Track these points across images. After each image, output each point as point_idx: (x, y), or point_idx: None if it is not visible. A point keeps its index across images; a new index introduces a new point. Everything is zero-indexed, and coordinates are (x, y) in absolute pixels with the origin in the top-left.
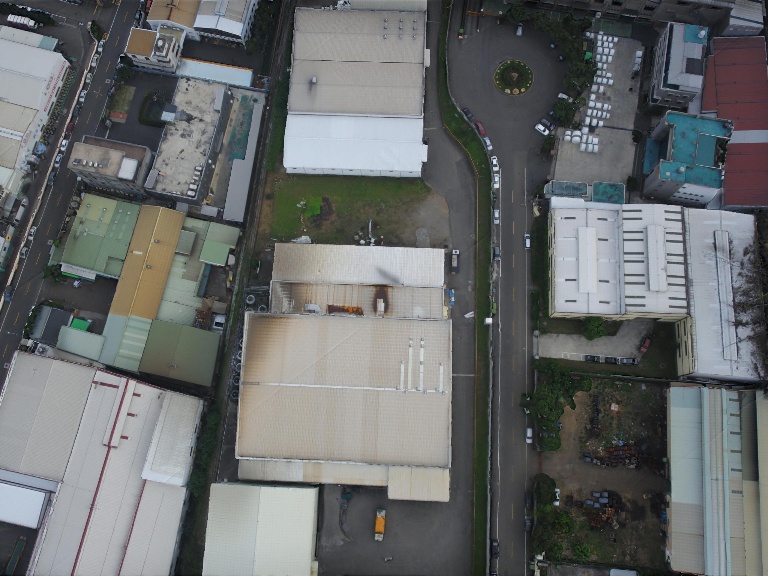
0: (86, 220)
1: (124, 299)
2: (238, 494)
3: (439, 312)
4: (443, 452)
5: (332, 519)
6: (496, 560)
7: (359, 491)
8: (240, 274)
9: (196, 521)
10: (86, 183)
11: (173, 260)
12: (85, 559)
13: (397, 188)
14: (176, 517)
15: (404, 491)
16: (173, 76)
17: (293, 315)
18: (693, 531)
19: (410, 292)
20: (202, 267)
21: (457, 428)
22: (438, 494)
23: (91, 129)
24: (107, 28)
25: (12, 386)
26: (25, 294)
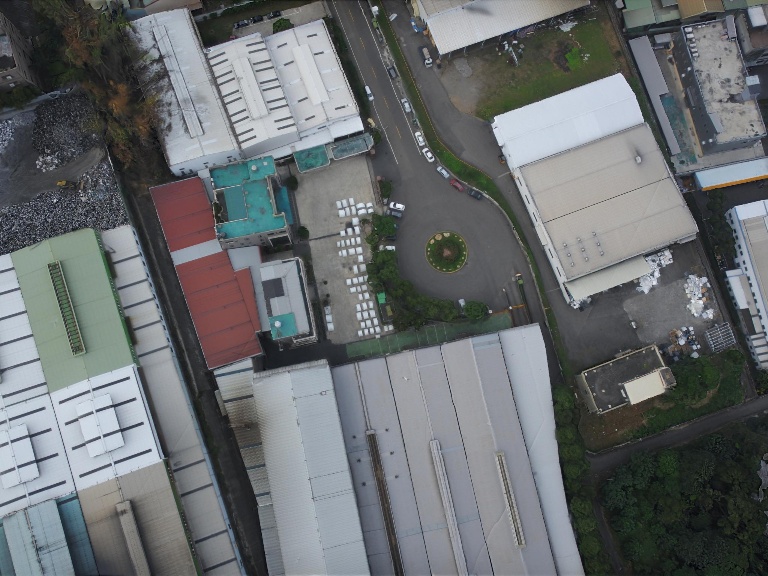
0: None
1: None
2: None
3: None
4: None
5: None
6: None
7: None
8: None
9: None
10: None
11: None
12: None
13: (508, 105)
14: None
15: None
16: None
17: None
18: None
19: (454, 3)
20: None
21: None
22: None
23: None
24: None
25: None
26: None
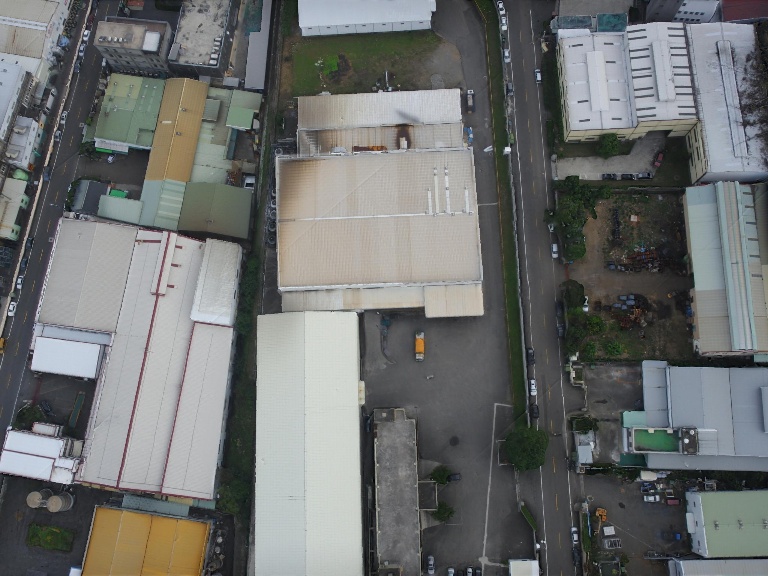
0: (115, 97)
1: (158, 165)
2: (284, 321)
3: (460, 144)
4: (474, 268)
5: (374, 345)
6: (533, 367)
7: (397, 317)
8: (266, 135)
9: (245, 359)
10: (111, 68)
11: (201, 127)
12: (144, 398)
13: (409, 40)
14: (226, 355)
15: (440, 309)
16: None
17: (321, 157)
18: (718, 314)
19: (430, 129)
20: (229, 132)
21: (485, 253)
22: (473, 309)
23: None
24: None
25: (59, 251)
26: (62, 174)
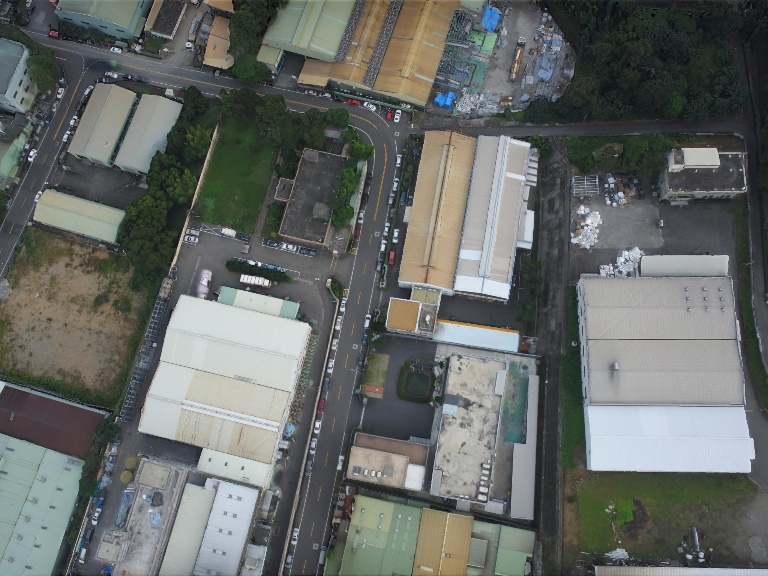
0: (362, 528)
1: None
2: None
3: None
4: None
5: None
6: None
7: None
8: None
9: None
10: None
11: (465, 574)
12: None
13: (718, 486)
14: None
15: None
16: (429, 341)
17: None
18: None
19: None
20: None
21: None
22: None
23: (344, 406)
24: (346, 283)
25: None
26: None
